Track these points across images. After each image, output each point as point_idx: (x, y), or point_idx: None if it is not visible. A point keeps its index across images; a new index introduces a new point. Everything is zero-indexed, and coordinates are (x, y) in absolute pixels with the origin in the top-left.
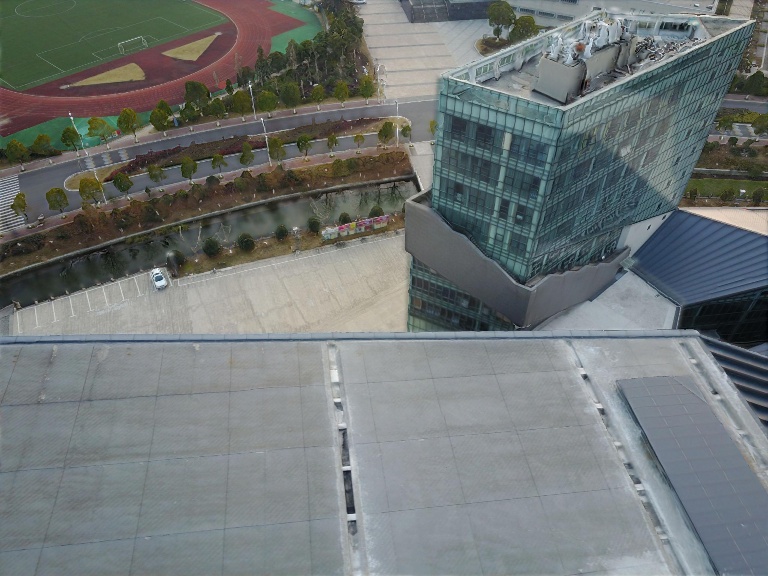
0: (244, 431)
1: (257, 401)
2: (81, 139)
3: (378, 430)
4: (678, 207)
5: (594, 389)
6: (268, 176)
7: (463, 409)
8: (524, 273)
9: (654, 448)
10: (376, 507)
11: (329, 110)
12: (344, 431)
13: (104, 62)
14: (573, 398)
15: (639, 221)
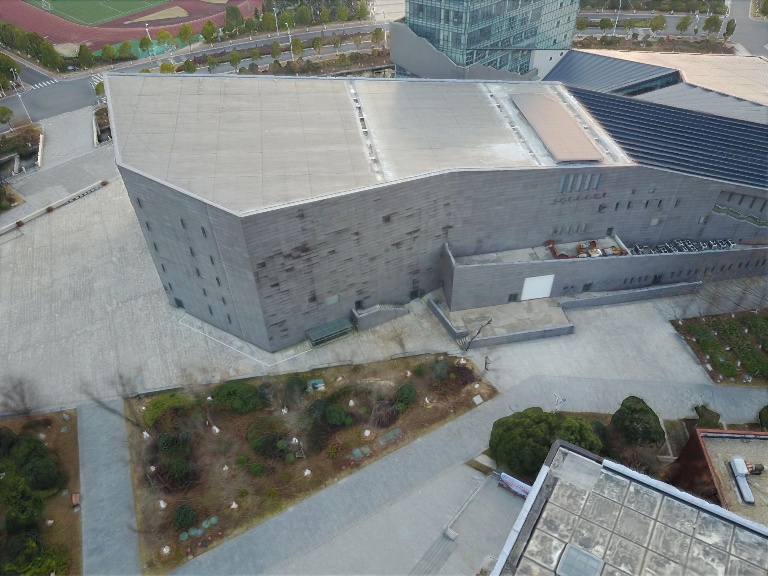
0: (307, 105)
1: (312, 97)
2: (153, 46)
3: (377, 107)
4: (572, 49)
5: (496, 100)
6: (293, 62)
7: (422, 103)
8: (462, 61)
9: (523, 114)
10: (377, 127)
11: (333, 29)
12: (359, 107)
13: (154, 6)
14: (483, 101)
15: (541, 49)
